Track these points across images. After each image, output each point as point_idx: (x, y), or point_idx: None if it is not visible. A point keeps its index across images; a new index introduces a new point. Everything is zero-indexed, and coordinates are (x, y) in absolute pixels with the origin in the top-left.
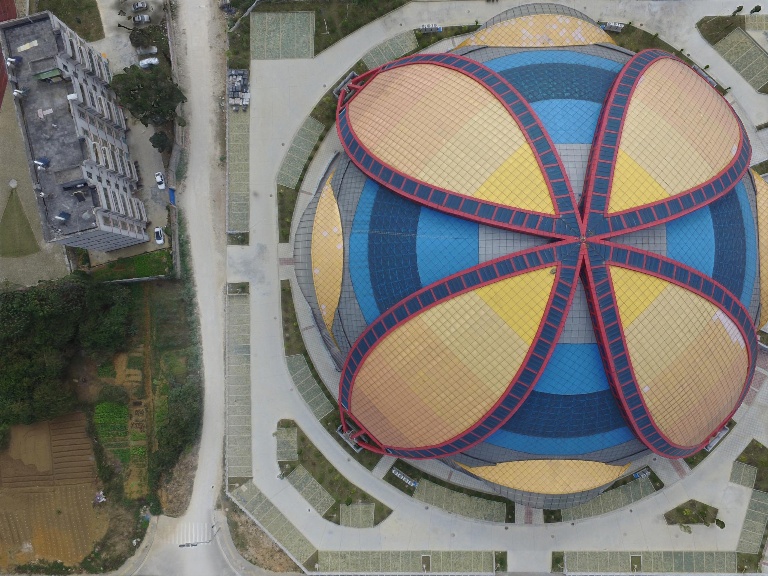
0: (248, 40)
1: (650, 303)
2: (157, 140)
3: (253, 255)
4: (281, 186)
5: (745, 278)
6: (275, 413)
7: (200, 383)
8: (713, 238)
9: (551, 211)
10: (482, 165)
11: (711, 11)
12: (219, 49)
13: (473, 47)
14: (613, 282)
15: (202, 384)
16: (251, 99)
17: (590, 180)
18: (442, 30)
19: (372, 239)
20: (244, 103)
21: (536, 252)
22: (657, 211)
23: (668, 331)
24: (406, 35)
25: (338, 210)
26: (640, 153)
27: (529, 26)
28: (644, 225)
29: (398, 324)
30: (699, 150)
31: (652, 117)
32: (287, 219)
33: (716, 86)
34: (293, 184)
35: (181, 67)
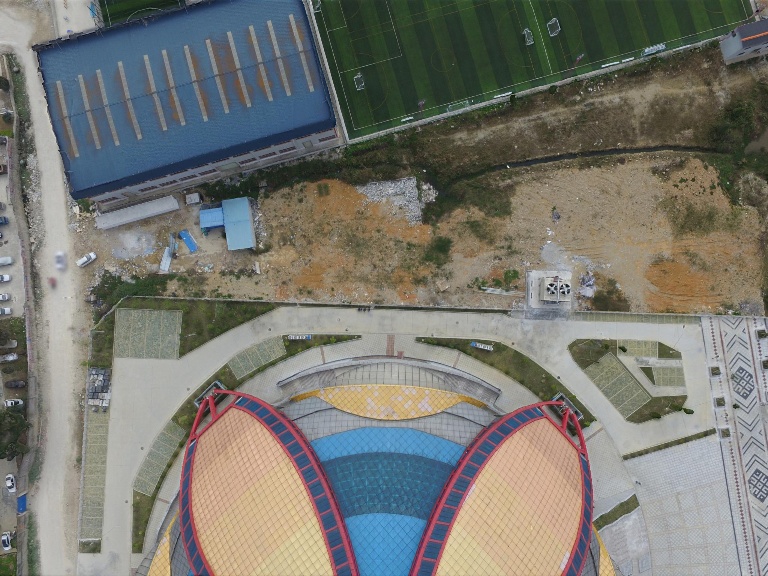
0: (112, 338)
1: None
2: (3, 456)
3: (105, 563)
4: (137, 492)
5: None
6: None
7: None
8: None
9: None
10: None
11: (584, 333)
12: (82, 345)
13: (321, 403)
14: None
15: None
16: (112, 399)
17: None
18: (311, 338)
19: None
20: (103, 405)
21: None
22: None
23: None
24: (274, 341)
25: (170, 575)
26: None
27: (374, 396)
28: None
29: None
30: None
31: (472, 550)
32: (139, 532)
33: (584, 412)
34: (150, 491)
35: (42, 361)
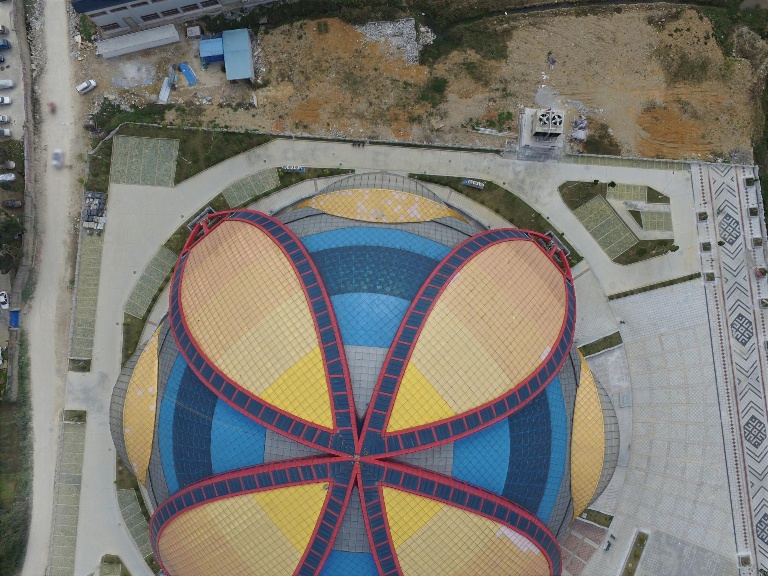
0: (109, 163)
1: (424, 523)
2: None
3: (93, 383)
4: (128, 315)
5: (548, 481)
6: (100, 547)
7: (27, 510)
8: (508, 448)
9: (330, 425)
10: (273, 364)
11: (574, 176)
12: (79, 169)
13: (312, 211)
14: (385, 502)
15: (29, 511)
16: (106, 223)
17: (372, 396)
18: (305, 171)
19: (177, 411)
20: (98, 228)
21: (310, 466)
22: (438, 432)
23: (444, 549)
24: (269, 172)
25: (157, 368)
26: (431, 367)
27: (364, 199)
28: (422, 446)
29: (186, 509)
30: (499, 361)
31: (454, 325)
32: (129, 351)
33: (572, 252)
34: (141, 314)
35: (39, 184)
